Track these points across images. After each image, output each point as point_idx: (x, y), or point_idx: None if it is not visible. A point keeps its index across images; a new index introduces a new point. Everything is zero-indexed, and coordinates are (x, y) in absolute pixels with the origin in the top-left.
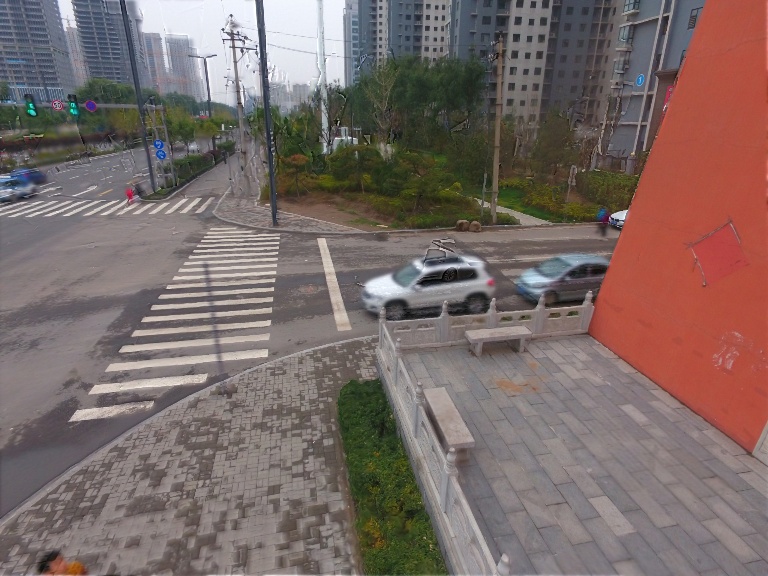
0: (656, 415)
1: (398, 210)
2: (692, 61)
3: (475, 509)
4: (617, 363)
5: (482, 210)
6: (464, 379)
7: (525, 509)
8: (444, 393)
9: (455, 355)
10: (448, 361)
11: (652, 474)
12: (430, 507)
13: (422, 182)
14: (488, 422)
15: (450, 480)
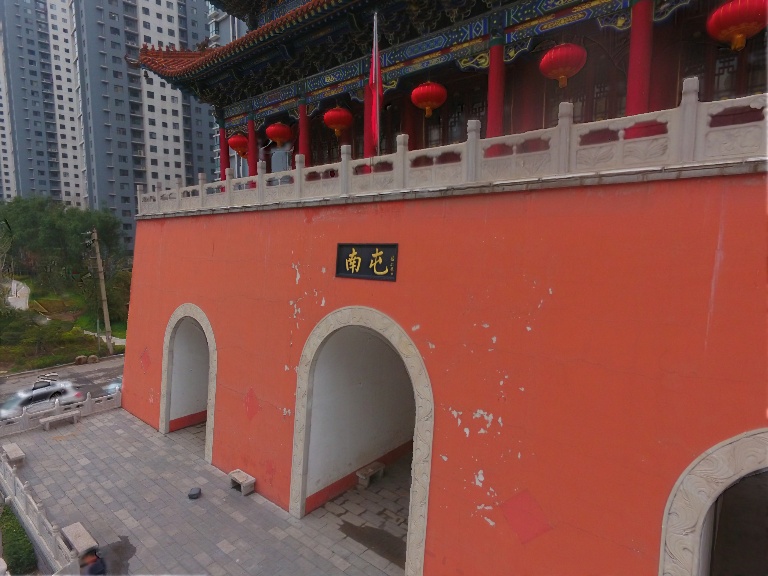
0: (129, 429)
1: (19, 356)
2: (132, 287)
3: (21, 476)
4: (127, 416)
5: (99, 346)
6: (34, 441)
7: (46, 470)
8: (14, 444)
9: (32, 433)
10: (27, 436)
11: (111, 447)
12: (0, 485)
13: (40, 332)
14: (41, 452)
15: (4, 463)
